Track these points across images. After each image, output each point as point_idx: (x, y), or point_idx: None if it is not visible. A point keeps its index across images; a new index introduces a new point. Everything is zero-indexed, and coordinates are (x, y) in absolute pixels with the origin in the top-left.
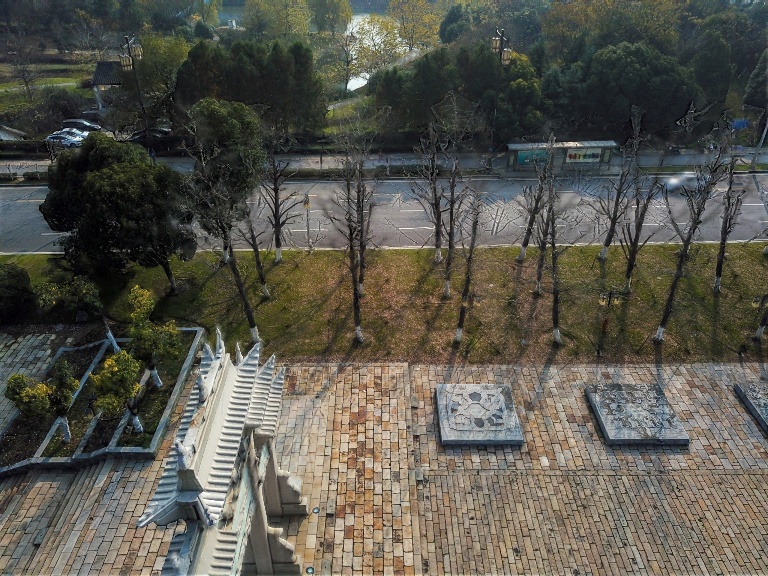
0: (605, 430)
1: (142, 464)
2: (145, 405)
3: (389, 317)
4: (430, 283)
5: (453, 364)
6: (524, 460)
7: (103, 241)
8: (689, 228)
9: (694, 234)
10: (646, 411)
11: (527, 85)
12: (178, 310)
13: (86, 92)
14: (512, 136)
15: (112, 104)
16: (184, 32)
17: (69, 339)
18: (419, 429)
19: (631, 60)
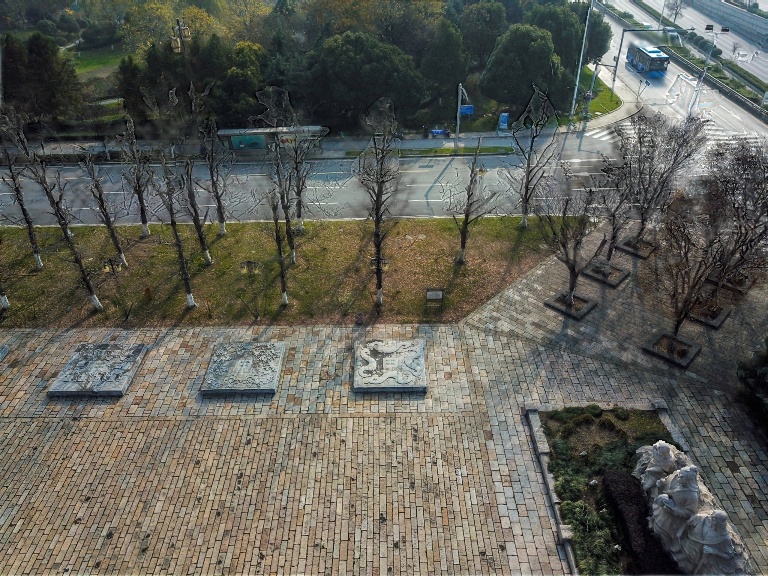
0: (53, 383)
1: None
2: None
3: None
4: None
5: None
6: None
7: None
8: None
9: (301, 211)
10: (106, 367)
11: (242, 73)
12: None
13: None
14: (229, 122)
15: None
16: None
17: None
18: None
19: (346, 48)
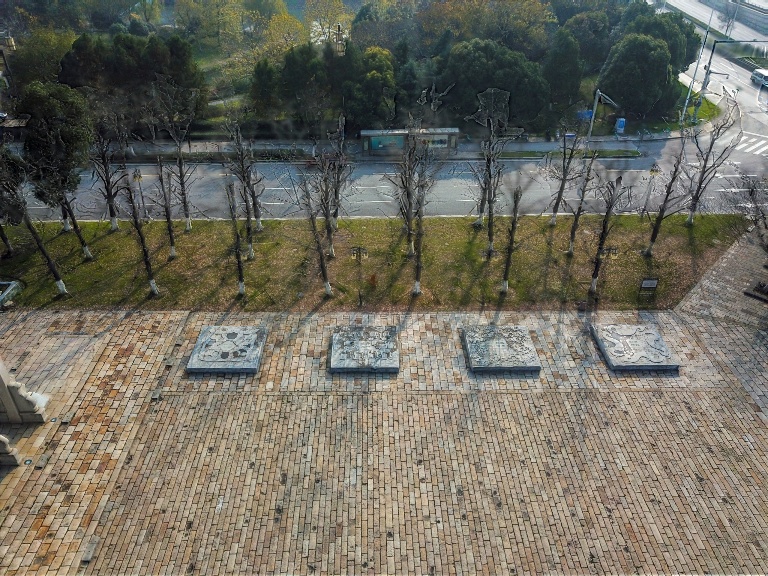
0: (331, 361)
1: None
2: None
3: (190, 275)
4: None
5: (230, 312)
6: (253, 384)
7: None
8: (480, 201)
9: (485, 206)
10: (373, 347)
11: (381, 76)
12: (7, 269)
13: None
14: (367, 123)
15: None
16: None
17: None
18: (174, 361)
19: (479, 55)
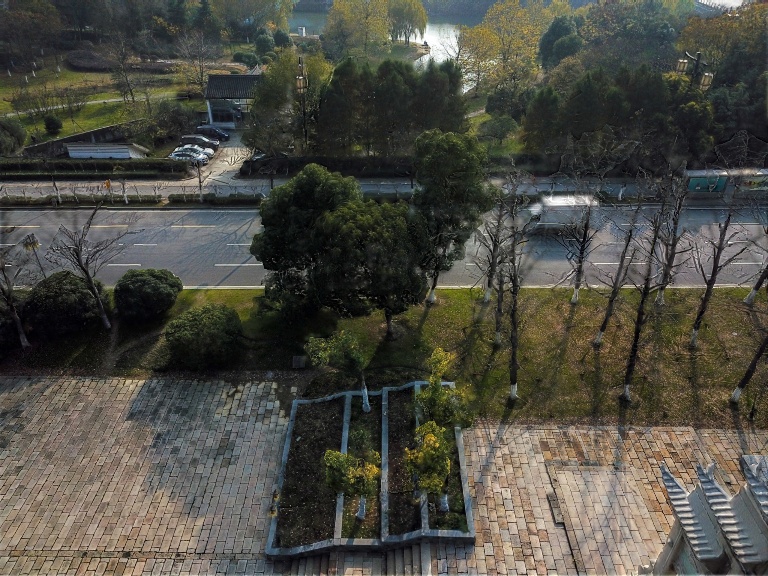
0: None
1: (463, 550)
2: None
3: (644, 371)
4: (667, 330)
5: (742, 429)
6: None
7: (352, 288)
8: None
9: None
10: None
11: (699, 108)
12: (405, 358)
13: (198, 106)
14: None
15: (269, 125)
16: (324, 48)
17: (293, 388)
18: None
19: None
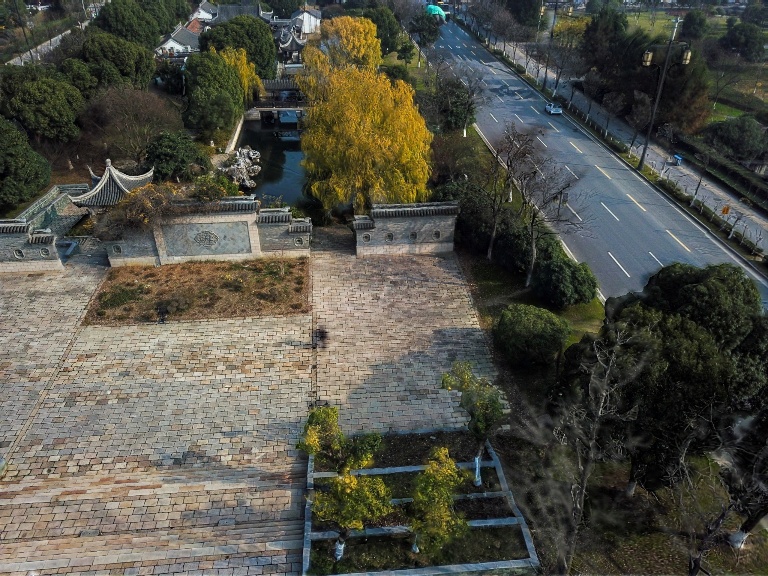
0: None
1: None
2: (379, 546)
3: None
4: None
5: None
6: None
7: (565, 379)
8: None
9: None
10: None
11: None
12: None
13: None
14: None
15: None
16: None
17: (507, 426)
18: None
19: None
